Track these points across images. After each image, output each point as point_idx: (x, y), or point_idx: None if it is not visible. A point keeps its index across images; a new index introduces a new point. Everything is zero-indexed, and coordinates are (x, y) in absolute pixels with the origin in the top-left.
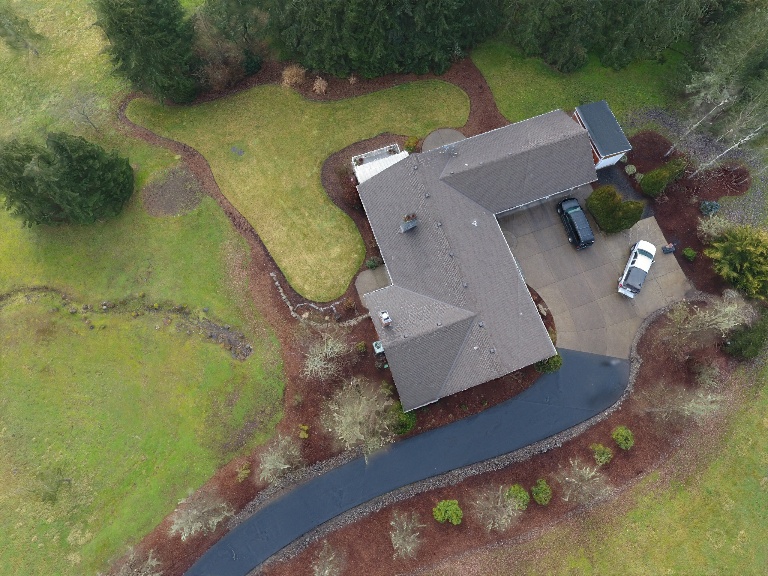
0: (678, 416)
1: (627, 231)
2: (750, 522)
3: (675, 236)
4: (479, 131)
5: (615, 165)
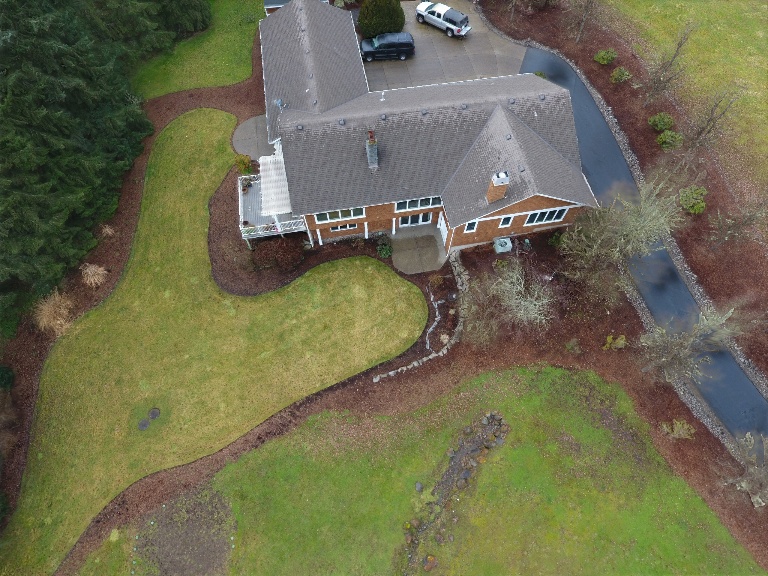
0: None
1: None
2: (668, 0)
3: None
4: (249, 105)
5: None
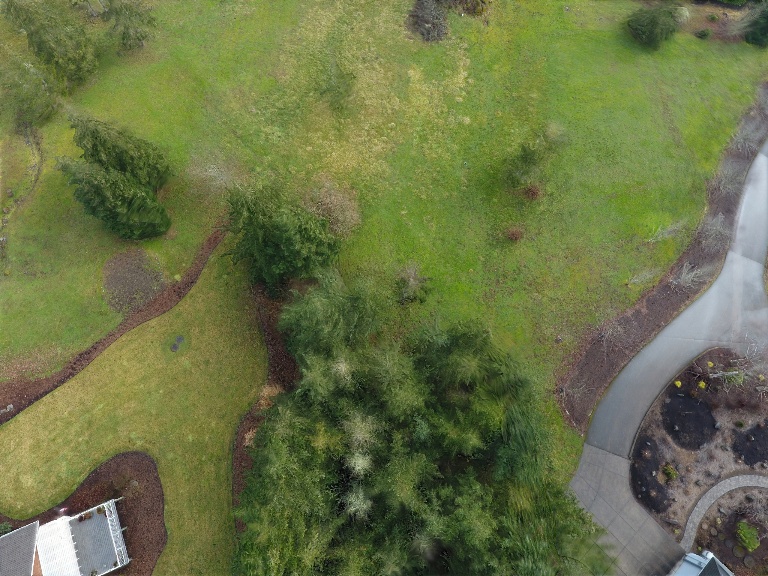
0: None
1: None
2: None
3: None
4: None
5: None
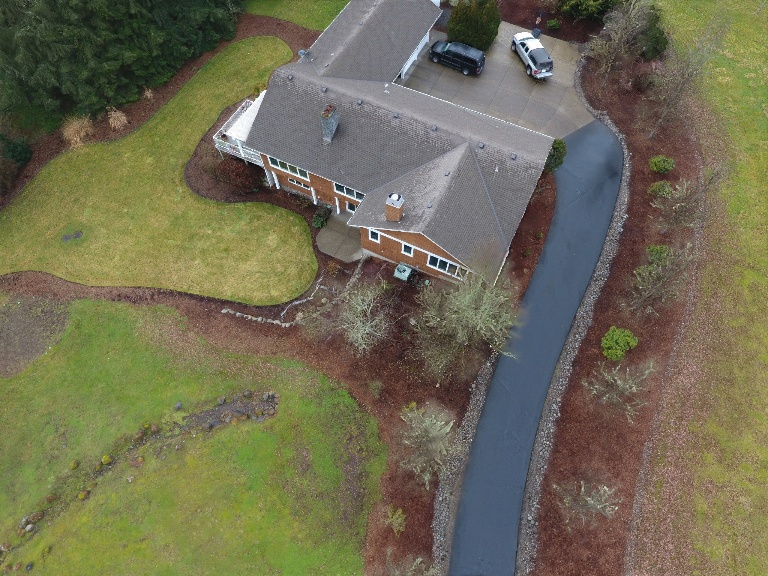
0: (671, 122)
1: (496, 41)
2: None
3: (530, 22)
4: None
5: (440, 8)
